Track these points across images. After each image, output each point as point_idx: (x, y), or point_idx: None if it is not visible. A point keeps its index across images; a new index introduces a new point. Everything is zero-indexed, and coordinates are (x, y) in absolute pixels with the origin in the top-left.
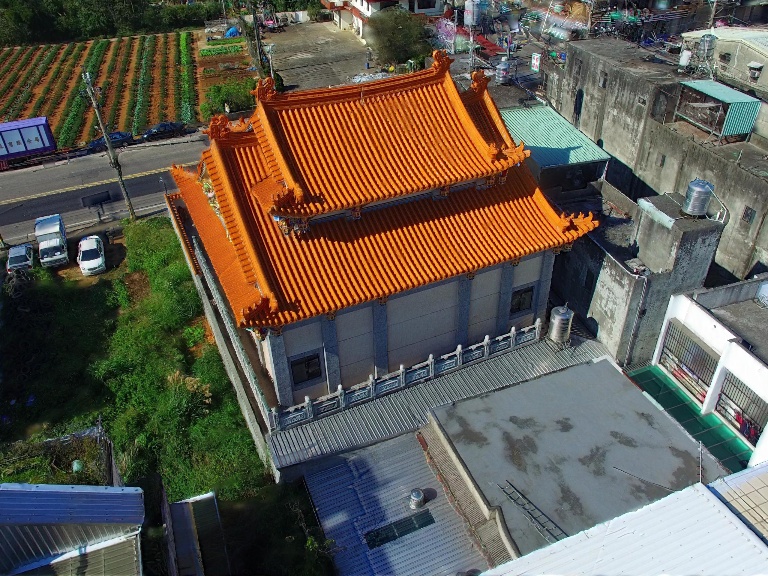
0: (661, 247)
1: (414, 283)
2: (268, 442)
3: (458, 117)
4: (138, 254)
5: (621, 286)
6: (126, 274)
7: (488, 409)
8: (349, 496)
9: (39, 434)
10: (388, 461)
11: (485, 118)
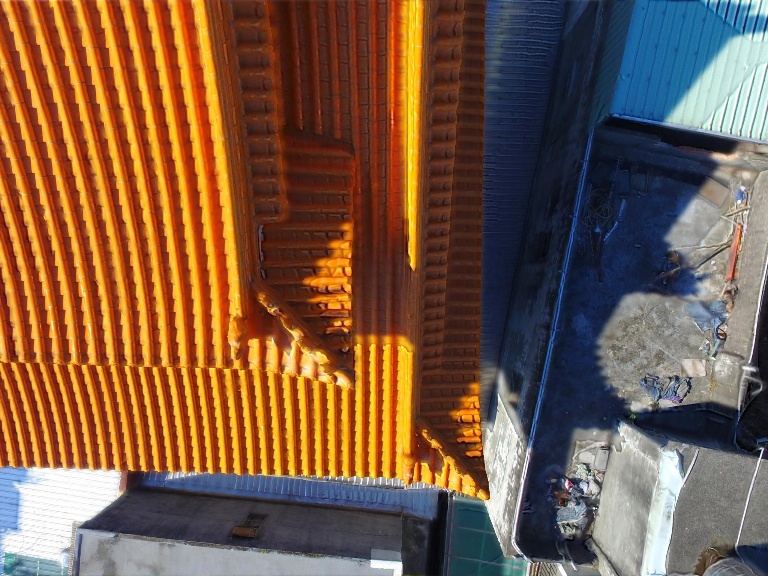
0: (621, 533)
1: (8, 463)
2: None
3: (207, 111)
4: None
5: (504, 508)
6: None
7: (157, 569)
8: (8, 496)
9: None
10: (71, 476)
11: (382, 62)
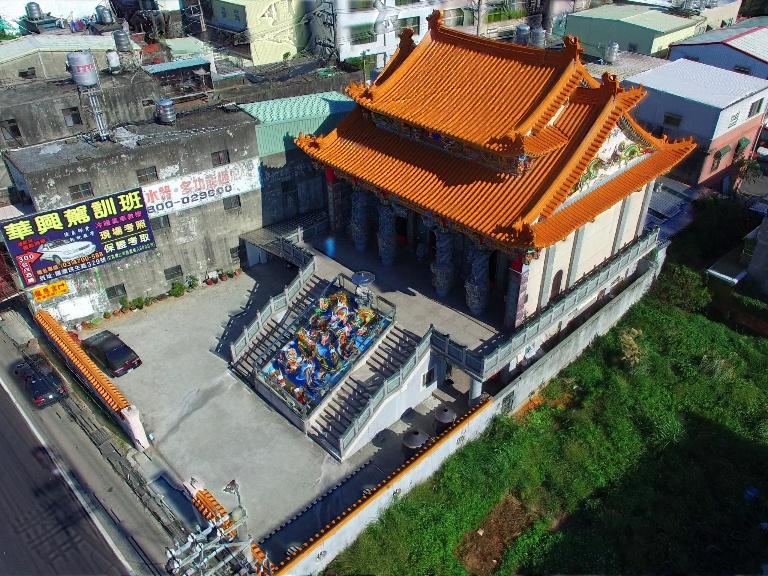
0: None
1: None
2: (661, 247)
3: None
4: (431, 573)
5: None
6: (477, 575)
7: None
8: None
9: (767, 441)
10: None
11: None
